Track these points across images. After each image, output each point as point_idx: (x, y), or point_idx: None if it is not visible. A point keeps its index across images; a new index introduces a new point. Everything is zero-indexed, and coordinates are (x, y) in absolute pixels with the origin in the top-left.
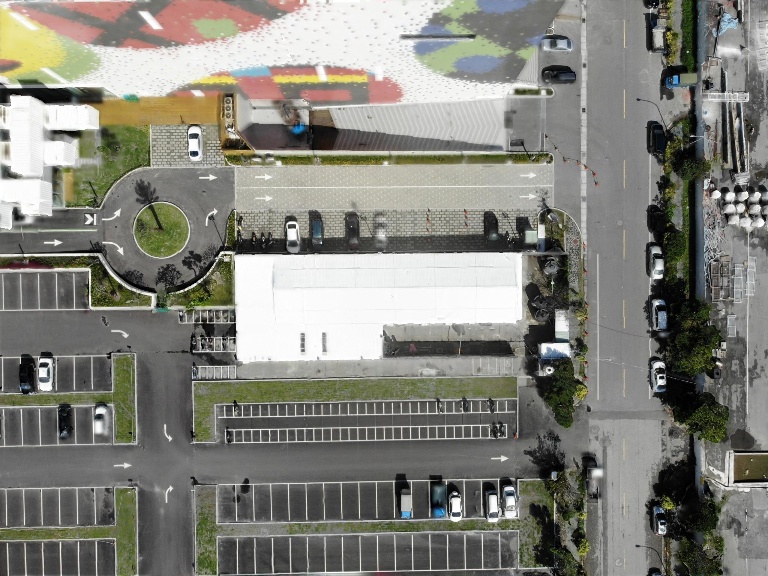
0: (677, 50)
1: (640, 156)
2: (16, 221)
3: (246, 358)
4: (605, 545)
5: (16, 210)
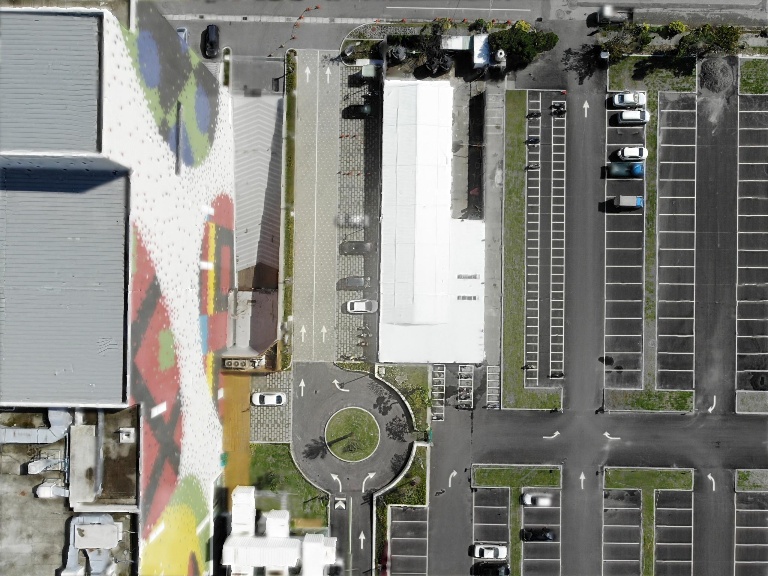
0: None
1: None
2: (340, 575)
3: (481, 354)
4: (676, 7)
5: (330, 575)
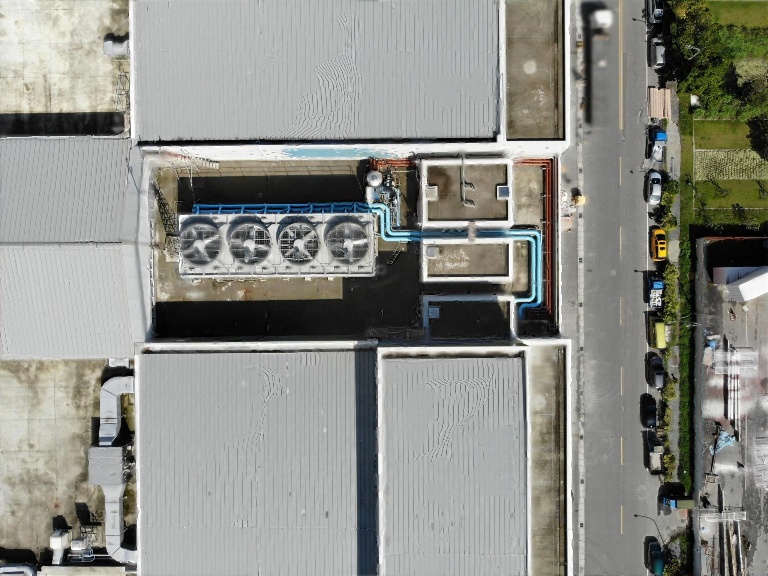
0: (674, 467)
1: (638, 571)
2: None
3: None
4: None
5: None
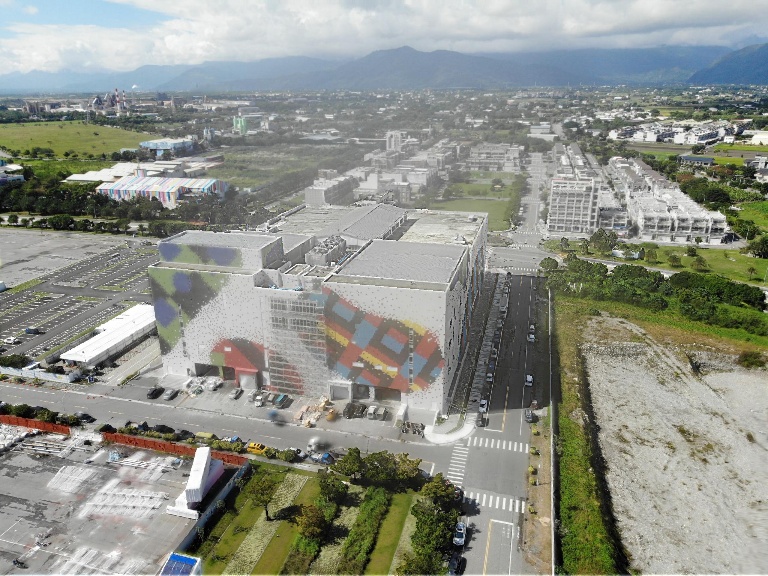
0: (122, 435)
1: None
2: None
3: None
4: None
5: None
